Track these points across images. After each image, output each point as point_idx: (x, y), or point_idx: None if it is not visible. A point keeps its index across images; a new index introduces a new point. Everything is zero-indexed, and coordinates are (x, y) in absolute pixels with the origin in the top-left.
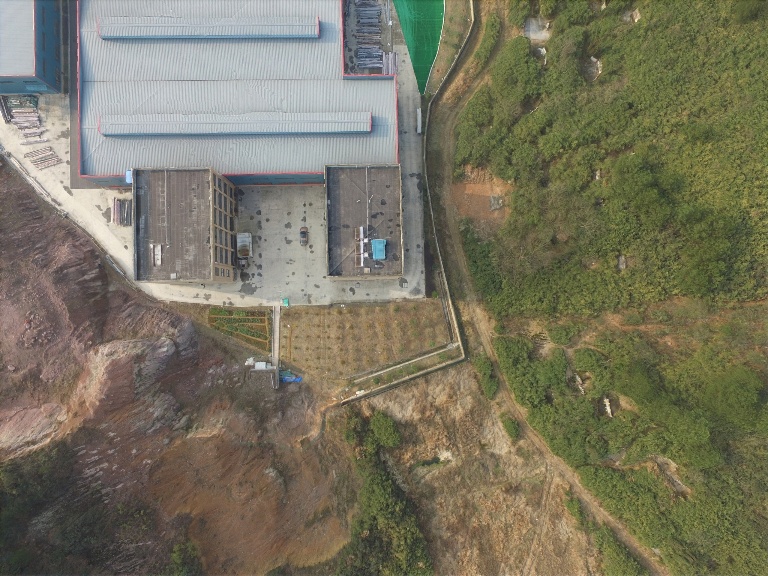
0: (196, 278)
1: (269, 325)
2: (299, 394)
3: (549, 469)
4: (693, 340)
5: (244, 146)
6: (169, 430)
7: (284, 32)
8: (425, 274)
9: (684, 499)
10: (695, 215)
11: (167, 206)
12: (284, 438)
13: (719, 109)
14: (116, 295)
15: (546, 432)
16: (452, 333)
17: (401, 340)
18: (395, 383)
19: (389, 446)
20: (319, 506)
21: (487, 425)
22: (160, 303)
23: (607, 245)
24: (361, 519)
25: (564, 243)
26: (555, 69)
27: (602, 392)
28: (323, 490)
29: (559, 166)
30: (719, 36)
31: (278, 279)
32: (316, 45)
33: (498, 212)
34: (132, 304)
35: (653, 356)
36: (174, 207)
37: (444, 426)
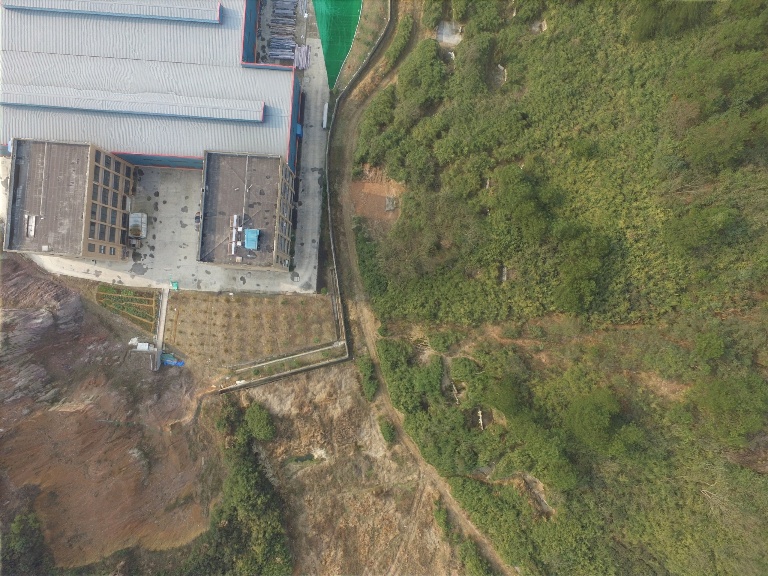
0: (67, 252)
1: (156, 307)
2: (179, 378)
3: (422, 477)
4: (564, 359)
5: (136, 126)
6: (32, 401)
7: (184, 15)
8: (317, 270)
9: (546, 519)
10: (569, 231)
11: (45, 178)
12: (155, 420)
13: (609, 126)
14: (6, 264)
15: (418, 439)
16: (340, 331)
17: (287, 334)
18: (276, 376)
19: (261, 438)
20: (183, 492)
21: (365, 427)
22: (50, 275)
23: (488, 255)
24: (221, 508)
25: (447, 249)
26: (459, 74)
27: (474, 403)
28: (189, 476)
29: (450, 172)
30: (618, 53)
31: (170, 262)
32: (218, 31)
33: (392, 213)
34: (21, 274)
35: (523, 371)
36: (52, 180)
37: (321, 424)
